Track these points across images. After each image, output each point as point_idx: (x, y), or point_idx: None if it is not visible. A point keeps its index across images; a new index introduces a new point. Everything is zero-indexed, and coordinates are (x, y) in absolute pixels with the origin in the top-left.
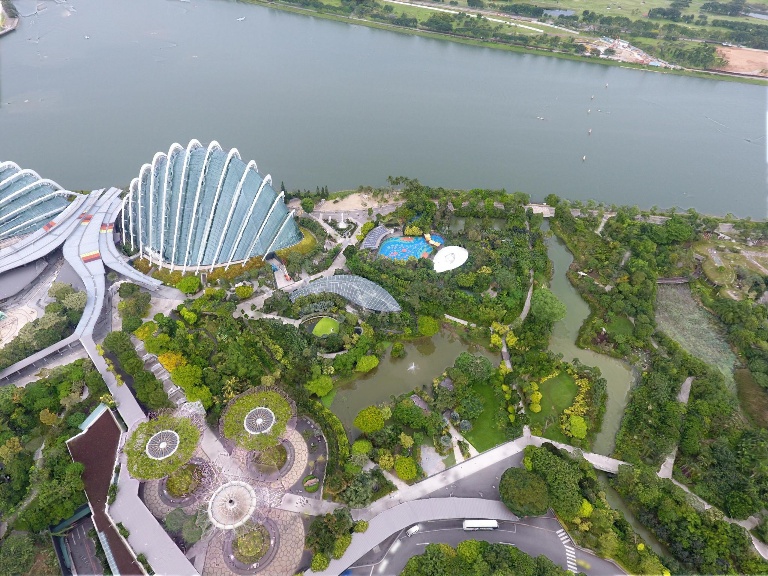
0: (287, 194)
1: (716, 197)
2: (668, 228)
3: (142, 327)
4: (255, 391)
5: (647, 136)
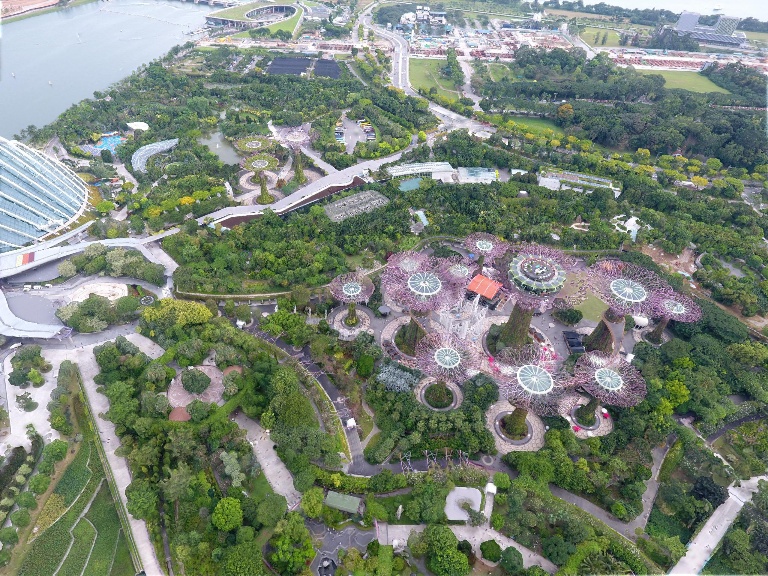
0: None
1: (129, 63)
2: (157, 70)
3: (148, 214)
4: (237, 145)
5: (40, 63)
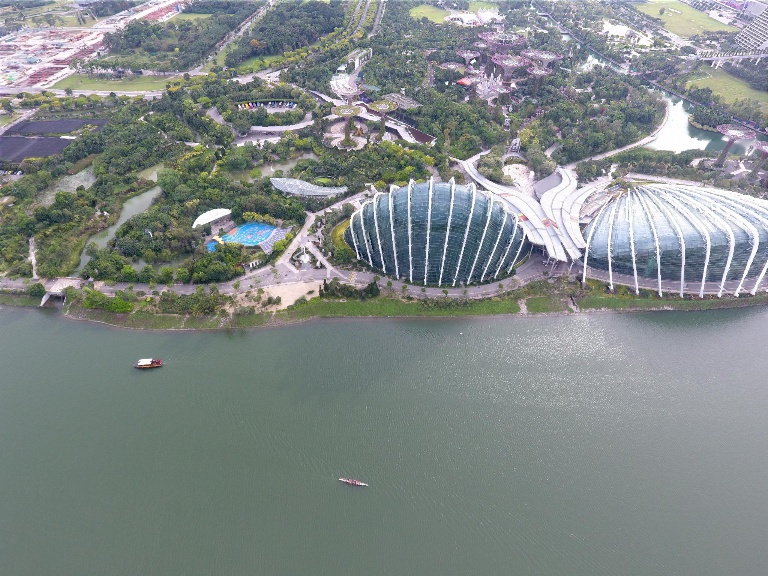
0: (370, 286)
1: None
2: None
3: None
4: None
5: None
